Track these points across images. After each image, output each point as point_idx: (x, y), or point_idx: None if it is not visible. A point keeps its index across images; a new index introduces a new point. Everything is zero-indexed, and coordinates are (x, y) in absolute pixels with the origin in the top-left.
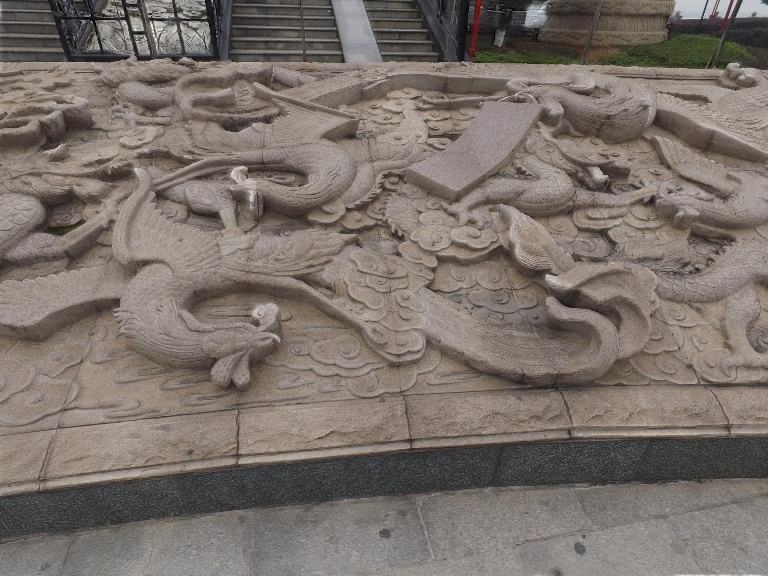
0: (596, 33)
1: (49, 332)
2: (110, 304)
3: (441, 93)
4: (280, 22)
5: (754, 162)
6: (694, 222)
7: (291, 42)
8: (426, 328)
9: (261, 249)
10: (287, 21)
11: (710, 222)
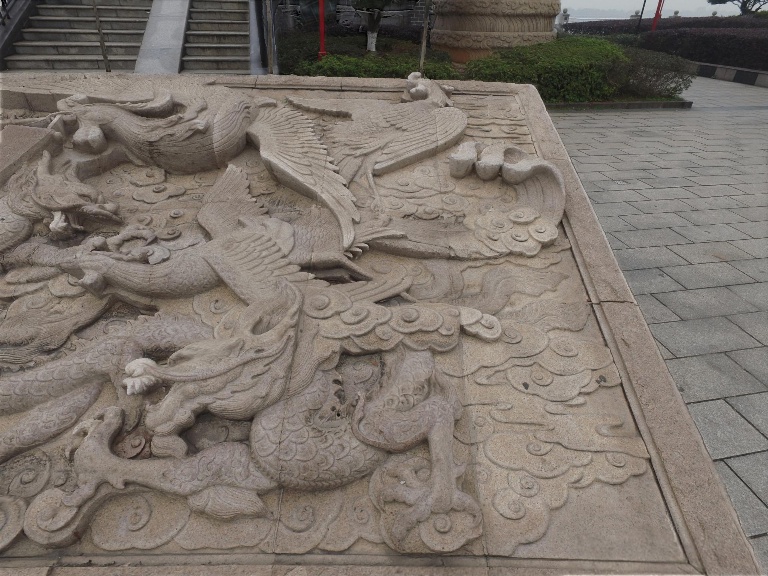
0: (475, 34)
1: None
2: None
3: (27, 112)
4: (86, 25)
5: (313, 199)
6: (116, 289)
7: (85, 47)
8: None
9: None
10: (94, 24)
11: (129, 290)
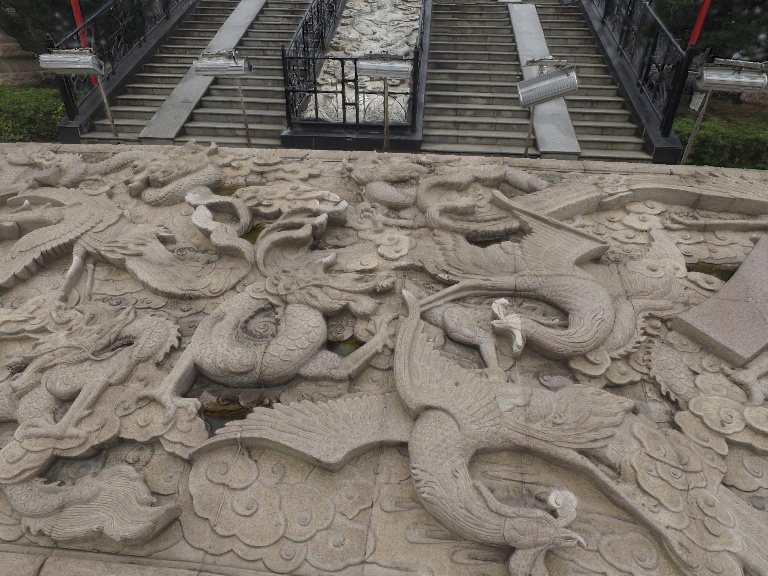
0: None
1: (343, 465)
2: (393, 444)
3: (689, 209)
4: (469, 88)
5: None
6: None
7: (480, 110)
8: (744, 554)
9: (537, 408)
10: (476, 87)
11: None
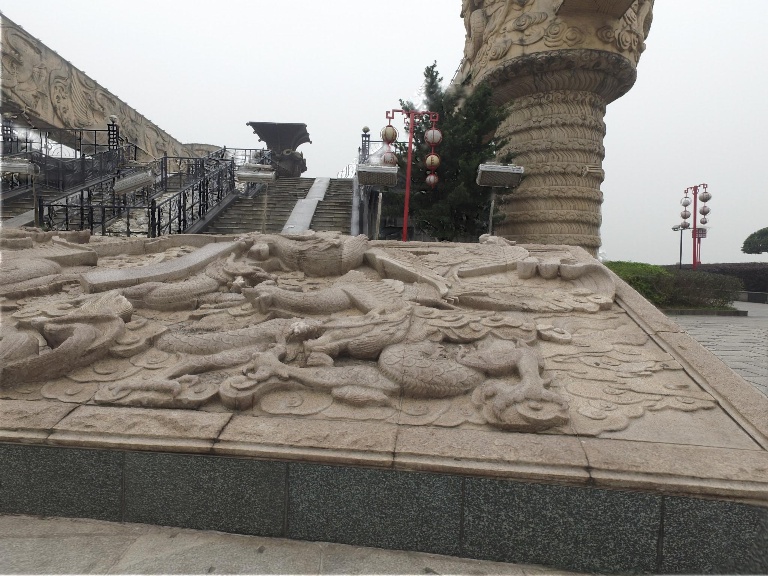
0: None
1: None
2: None
3: None
4: None
5: None
6: (277, 308)
7: None
8: None
9: None
10: None
11: (287, 307)
